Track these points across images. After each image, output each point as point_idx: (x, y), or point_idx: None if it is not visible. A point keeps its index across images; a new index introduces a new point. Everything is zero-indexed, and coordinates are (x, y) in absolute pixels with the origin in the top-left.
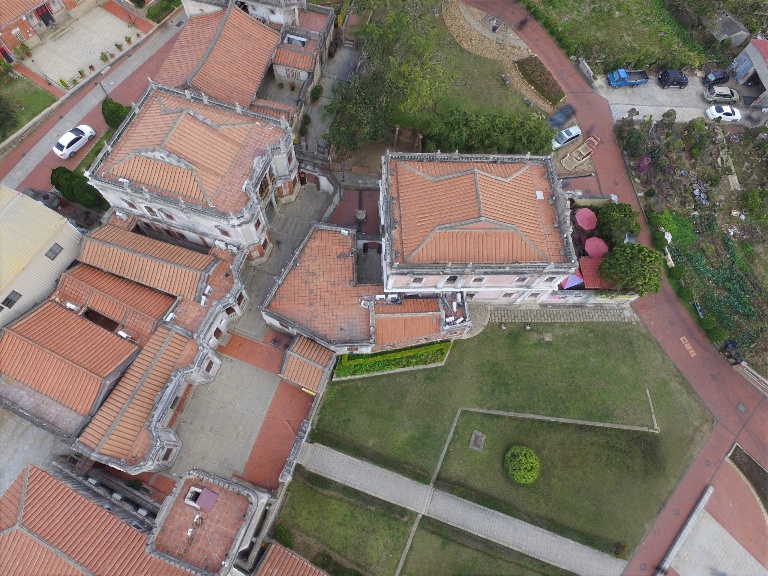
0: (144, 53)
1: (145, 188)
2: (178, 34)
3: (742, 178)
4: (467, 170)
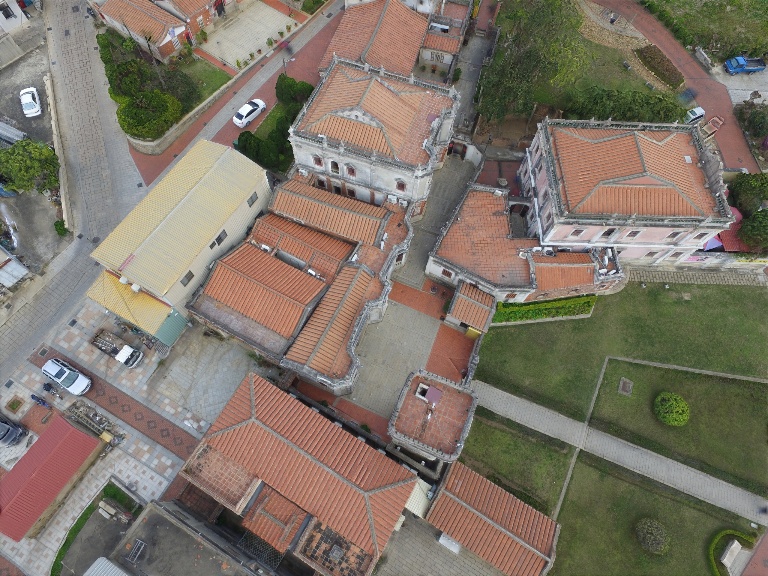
0: (301, 40)
1: None
2: (329, 24)
3: None
4: None
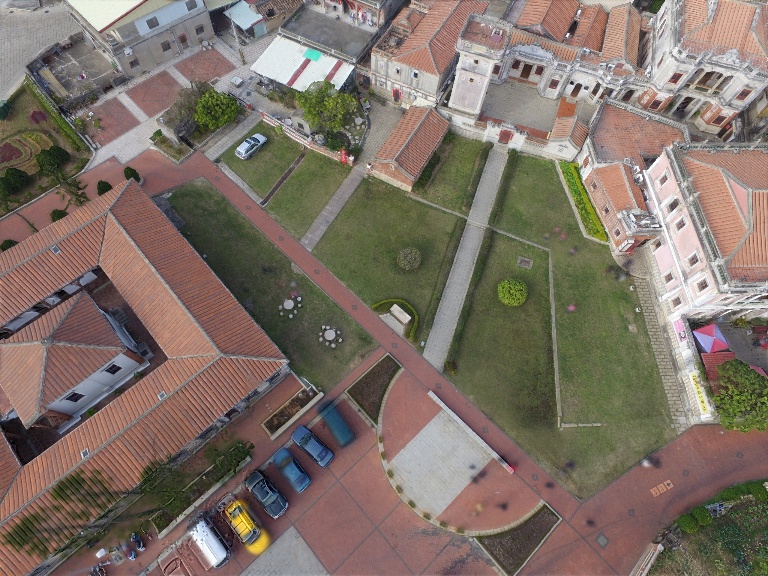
0: None
1: (682, 7)
2: None
3: None
4: None
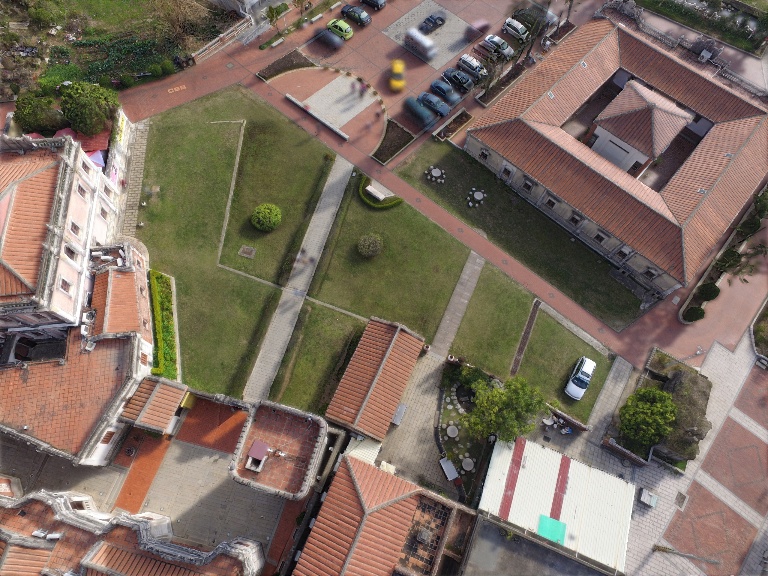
0: None
1: None
2: None
3: (17, 19)
4: None
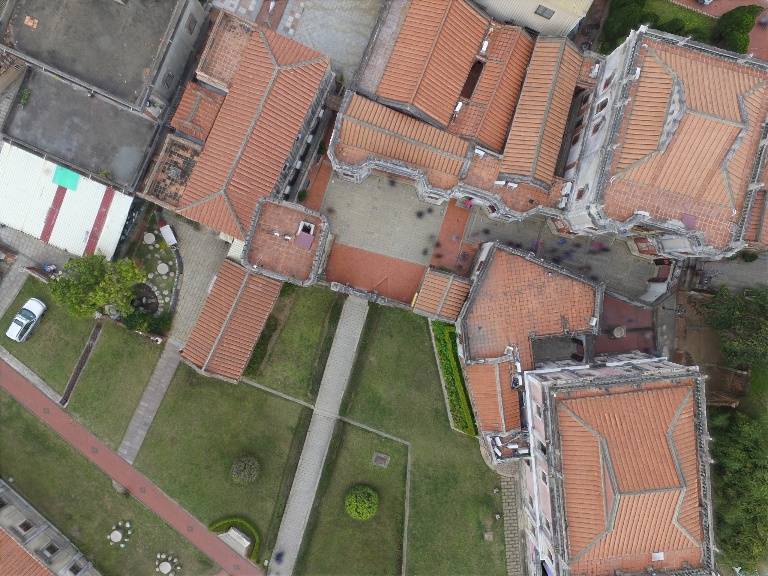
0: None
1: None
2: None
3: None
4: None
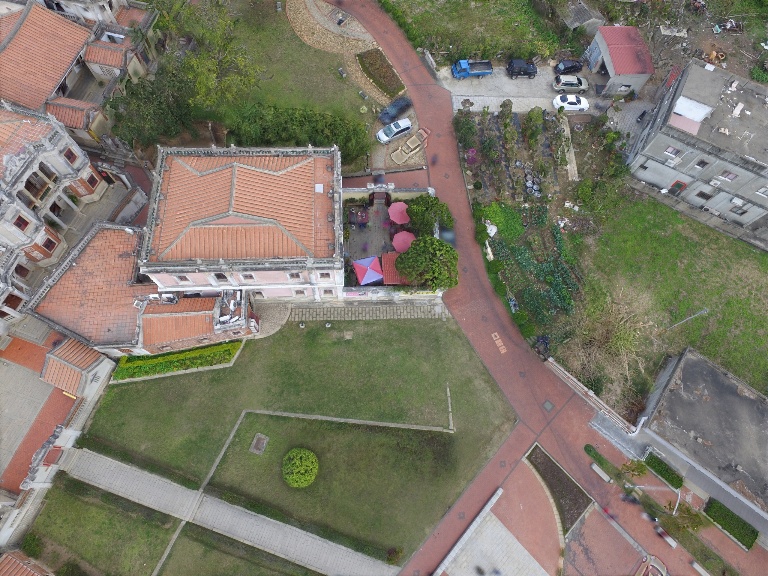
0: None
1: None
2: None
3: (582, 168)
4: (228, 164)
